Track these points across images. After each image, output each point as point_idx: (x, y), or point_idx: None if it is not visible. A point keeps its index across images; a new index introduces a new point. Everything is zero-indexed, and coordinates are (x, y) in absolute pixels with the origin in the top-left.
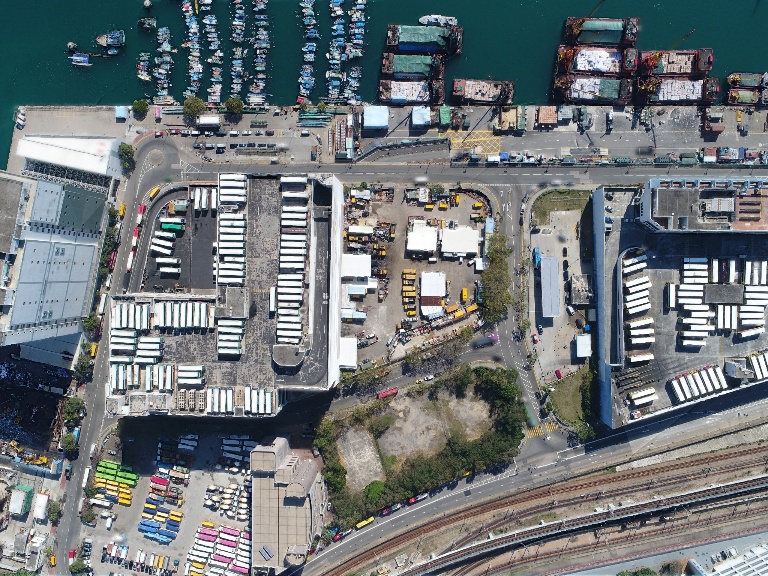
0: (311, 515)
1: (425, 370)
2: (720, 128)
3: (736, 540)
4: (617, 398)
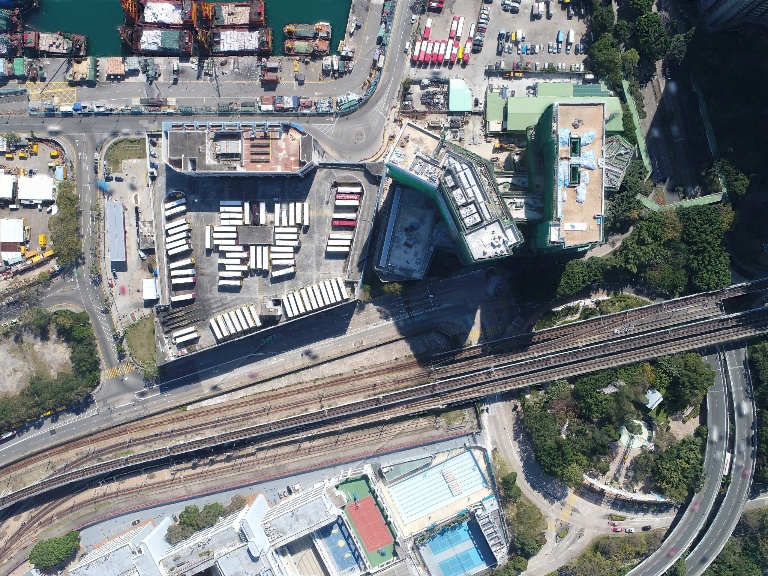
0: None
1: (10, 314)
2: (272, 77)
3: (301, 476)
4: (160, 336)
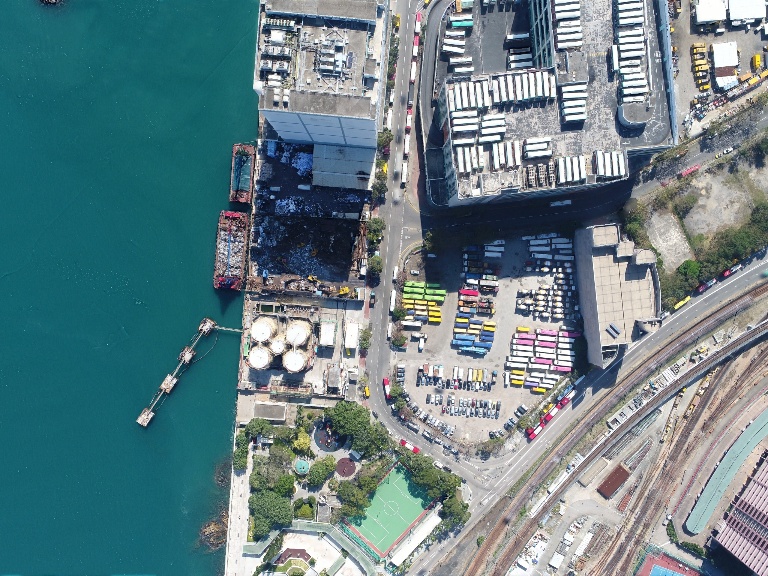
0: (654, 286)
1: (723, 144)
2: None
3: None
4: None
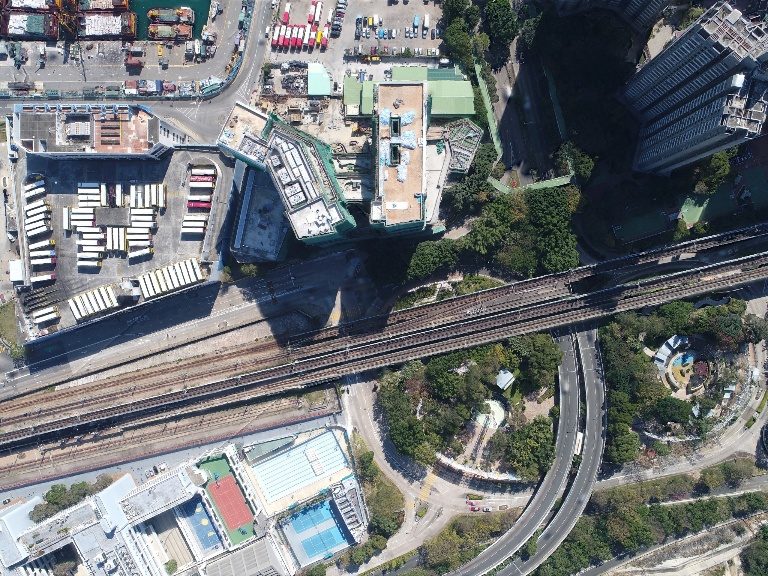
0: None
1: None
2: (134, 61)
3: (167, 455)
4: (20, 316)
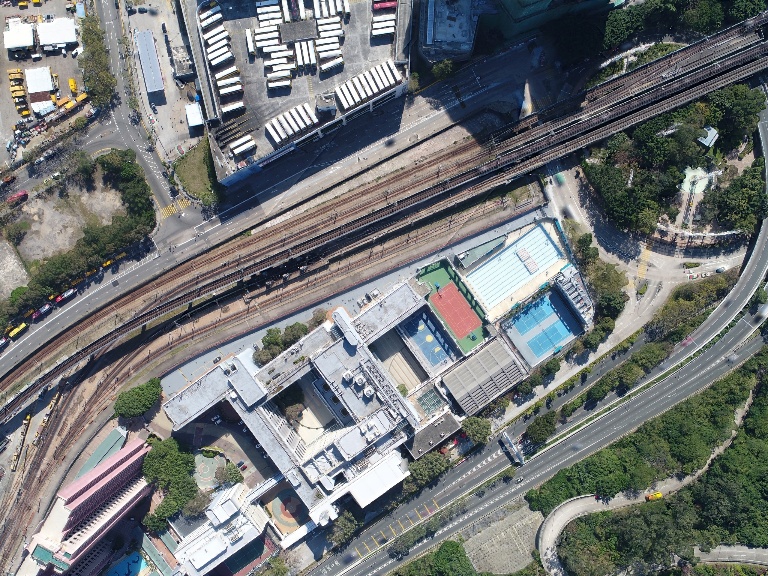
0: None
1: (50, 169)
2: None
3: (377, 281)
4: (217, 151)
